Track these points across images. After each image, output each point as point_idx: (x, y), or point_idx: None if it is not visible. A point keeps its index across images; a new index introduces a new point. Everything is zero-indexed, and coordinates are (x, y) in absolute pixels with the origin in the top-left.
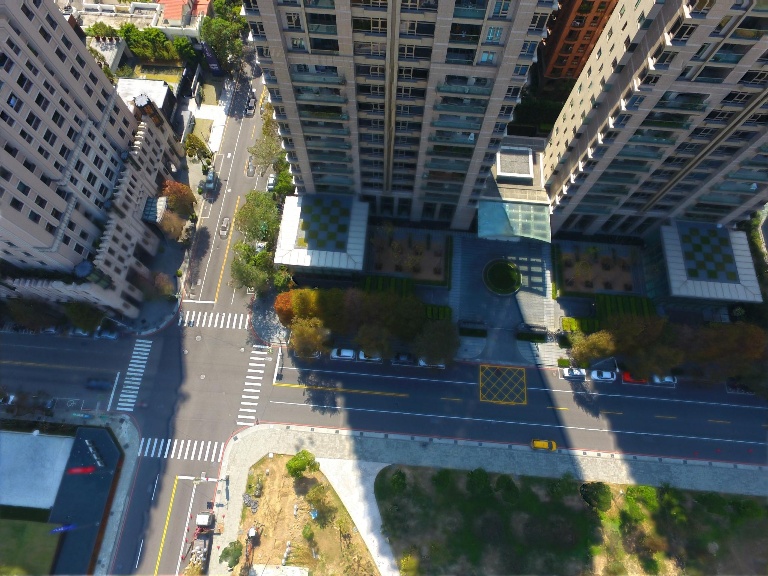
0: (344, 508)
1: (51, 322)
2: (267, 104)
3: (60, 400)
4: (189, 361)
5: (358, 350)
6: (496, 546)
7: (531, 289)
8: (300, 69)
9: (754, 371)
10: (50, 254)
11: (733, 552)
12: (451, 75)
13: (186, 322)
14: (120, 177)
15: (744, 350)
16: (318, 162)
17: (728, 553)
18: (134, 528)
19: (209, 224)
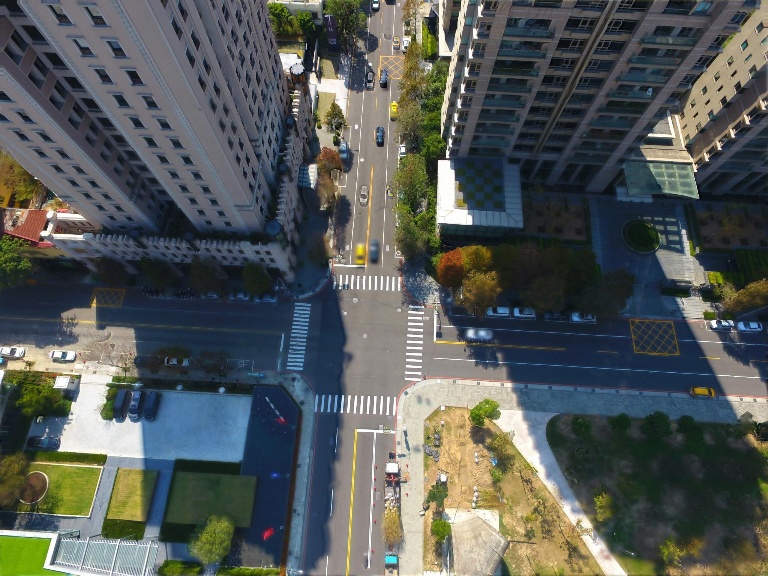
0: (521, 455)
1: None
2: (407, 73)
3: (230, 361)
4: (350, 322)
5: (511, 308)
6: (672, 486)
7: (669, 247)
8: (509, 24)
9: None
10: (244, 213)
11: None
12: (661, 26)
13: (341, 285)
14: (286, 142)
15: None
16: (480, 124)
17: None
18: (322, 479)
19: (347, 192)
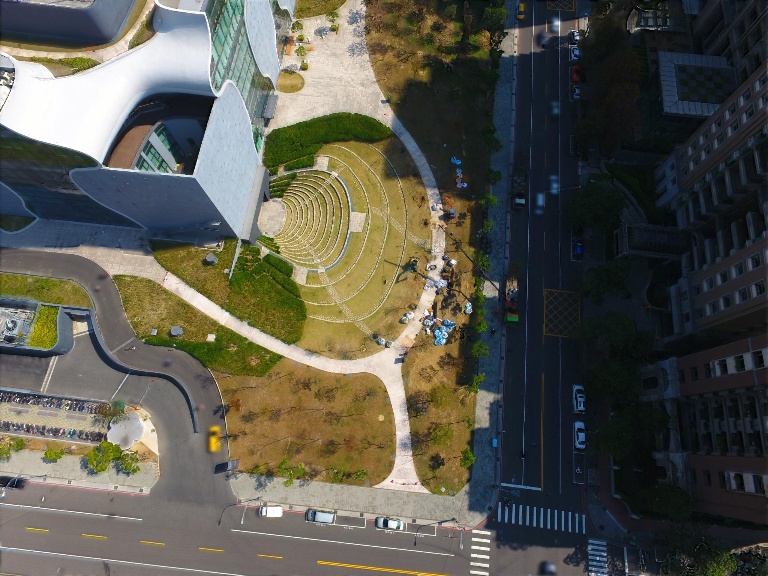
0: None
1: None
2: None
3: None
4: None
5: None
6: None
7: (641, 18)
8: None
9: None
10: None
11: (456, 101)
12: None
13: None
14: None
15: (617, 81)
16: None
17: (455, 98)
18: None
19: None
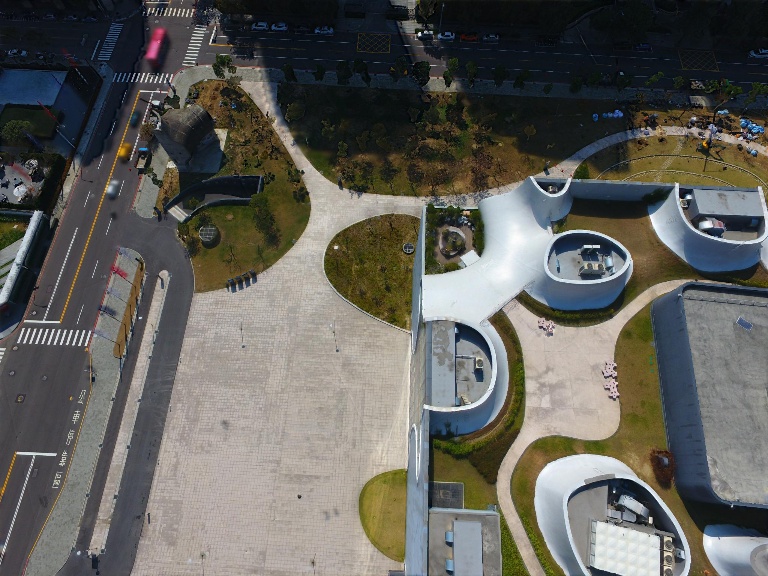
0: (255, 105)
1: (51, 10)
2: None
3: (58, 55)
4: (150, 33)
5: None
6: (358, 119)
7: None
8: None
9: (543, 11)
10: None
11: None
12: None
13: (148, 14)
14: None
15: None
16: None
17: None
18: (109, 116)
19: None
